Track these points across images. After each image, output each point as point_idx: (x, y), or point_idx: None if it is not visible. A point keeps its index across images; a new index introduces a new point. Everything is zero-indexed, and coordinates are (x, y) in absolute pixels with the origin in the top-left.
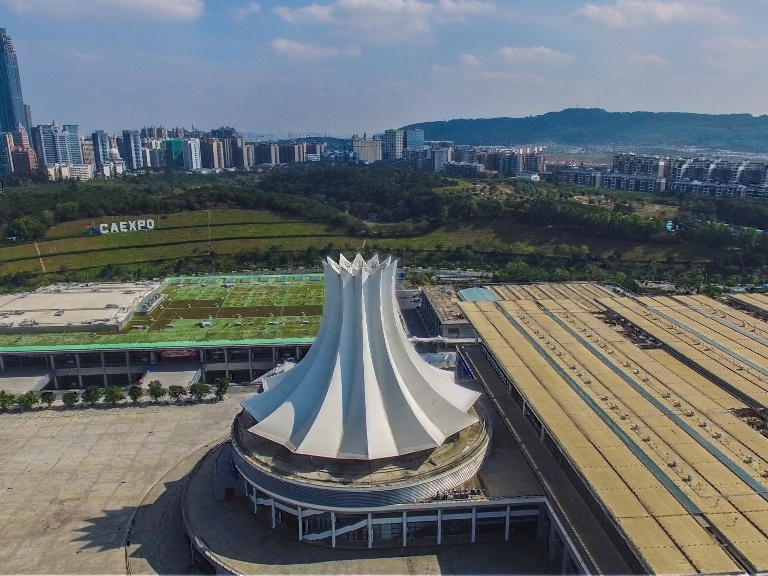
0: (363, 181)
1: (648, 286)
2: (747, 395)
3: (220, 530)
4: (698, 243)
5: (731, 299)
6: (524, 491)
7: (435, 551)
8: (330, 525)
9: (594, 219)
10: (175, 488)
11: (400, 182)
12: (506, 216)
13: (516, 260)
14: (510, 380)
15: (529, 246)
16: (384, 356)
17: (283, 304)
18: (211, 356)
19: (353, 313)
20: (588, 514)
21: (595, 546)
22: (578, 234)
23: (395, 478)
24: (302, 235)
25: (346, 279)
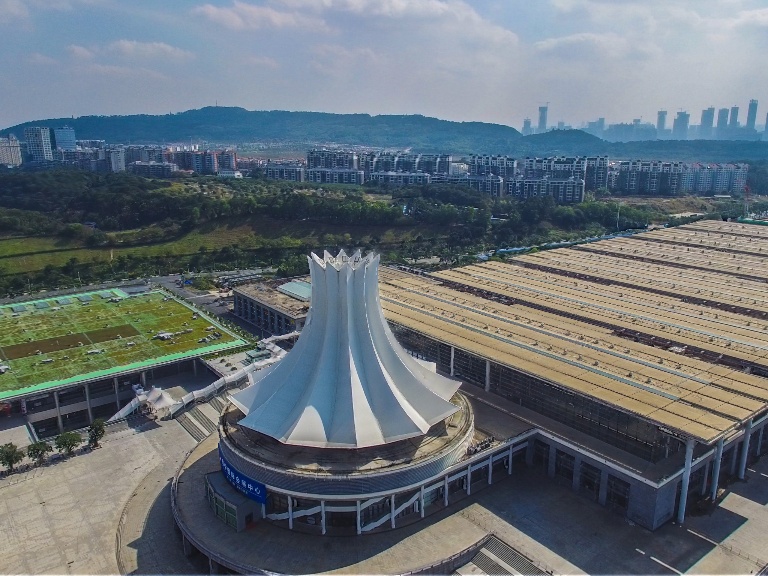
0: (50, 187)
1: (417, 262)
2: (608, 323)
3: (275, 555)
4: (432, 223)
5: (512, 261)
6: (519, 429)
7: (472, 500)
8: (383, 510)
9: (348, 209)
10: (147, 545)
11: (94, 186)
12: (258, 213)
13: (286, 254)
14: (454, 346)
15: (295, 239)
16: (385, 342)
17: (81, 331)
18: (31, 404)
19: (353, 306)
20: (573, 431)
21: (601, 449)
22: (333, 224)
23: (441, 446)
24: (27, 253)
25: (349, 274)
